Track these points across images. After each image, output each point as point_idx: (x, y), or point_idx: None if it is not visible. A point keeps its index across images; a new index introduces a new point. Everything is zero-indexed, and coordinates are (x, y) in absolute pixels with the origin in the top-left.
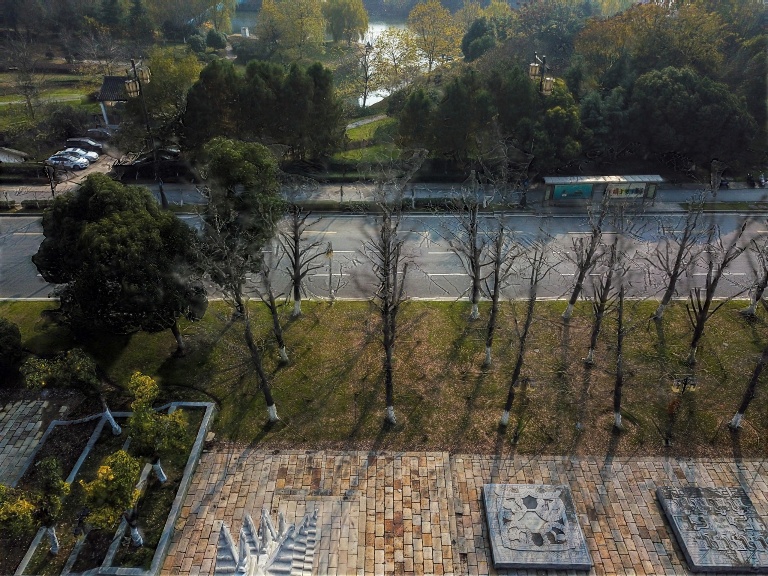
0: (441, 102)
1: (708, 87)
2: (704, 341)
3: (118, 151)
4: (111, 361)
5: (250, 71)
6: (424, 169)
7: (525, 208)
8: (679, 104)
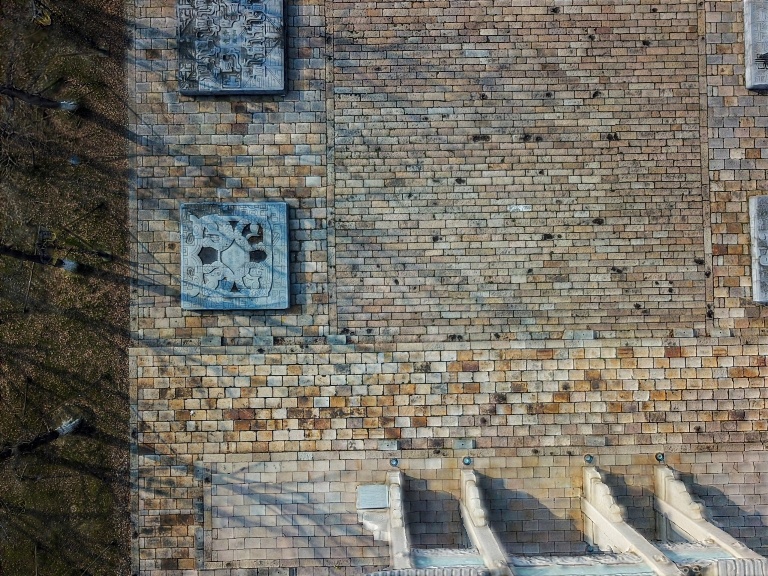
0: None
1: None
2: None
3: None
4: None
5: None
6: None
7: None
8: None
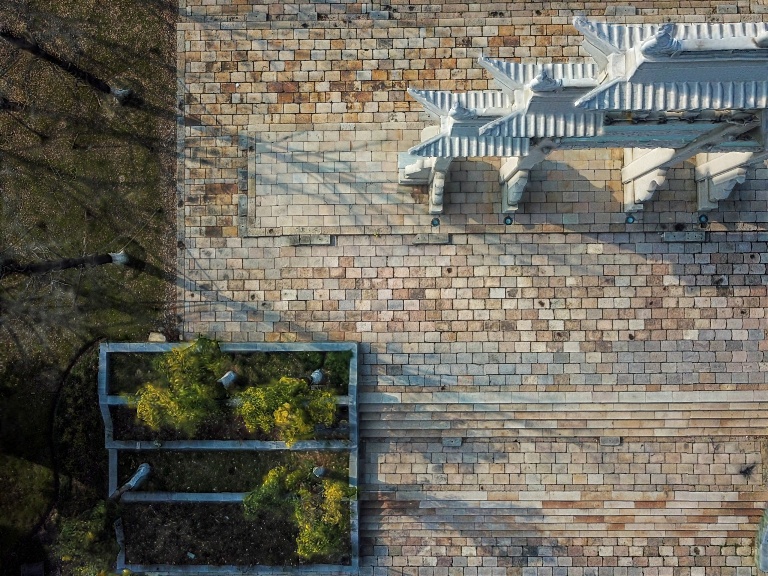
0: None
1: None
2: None
3: None
4: None
5: None
6: None
7: None
8: None
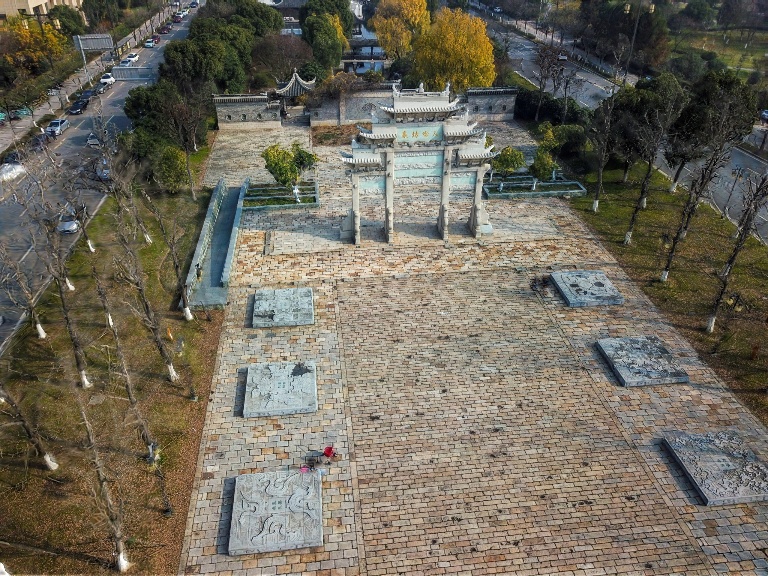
0: None
1: None
2: None
3: (763, 100)
4: (596, 170)
5: None
6: None
7: None
8: None
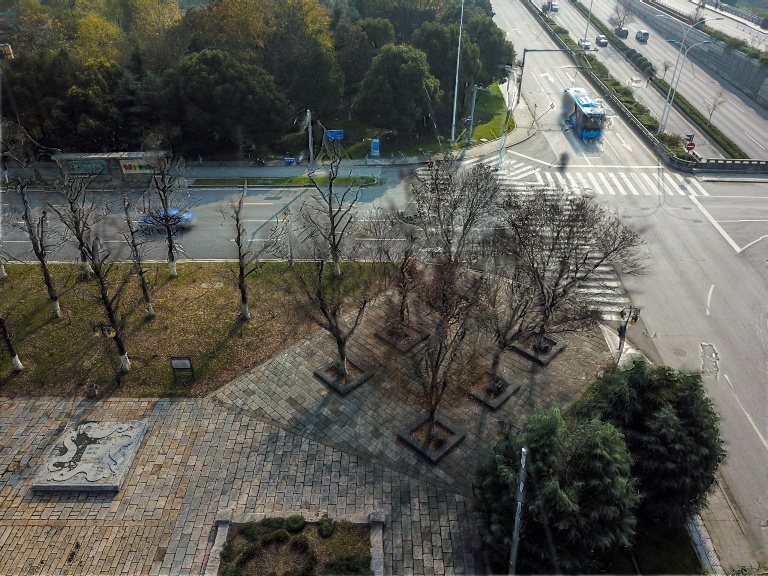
0: None
1: (229, 68)
2: (7, 298)
3: None
4: None
5: None
6: None
7: (41, 183)
8: (195, 84)
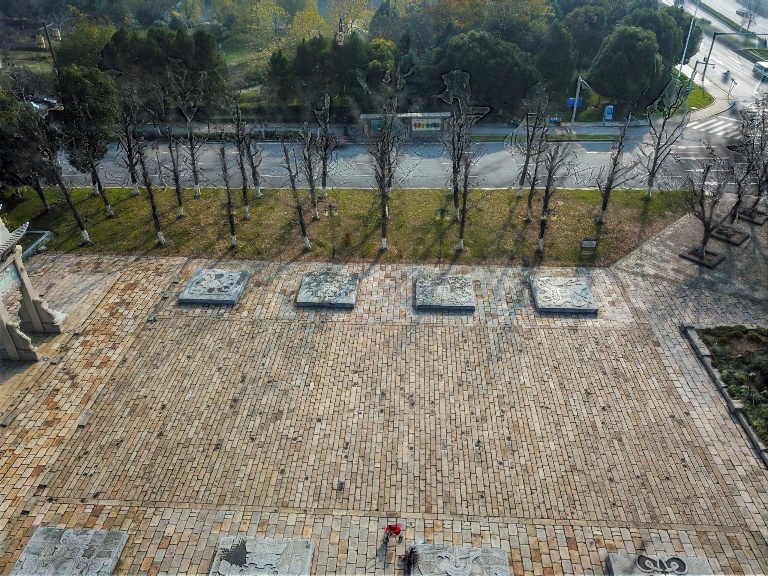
0: (295, 59)
1: (497, 45)
2: (406, 209)
3: (41, 93)
4: None
5: (149, 36)
6: (285, 113)
7: (348, 138)
8: (471, 58)
